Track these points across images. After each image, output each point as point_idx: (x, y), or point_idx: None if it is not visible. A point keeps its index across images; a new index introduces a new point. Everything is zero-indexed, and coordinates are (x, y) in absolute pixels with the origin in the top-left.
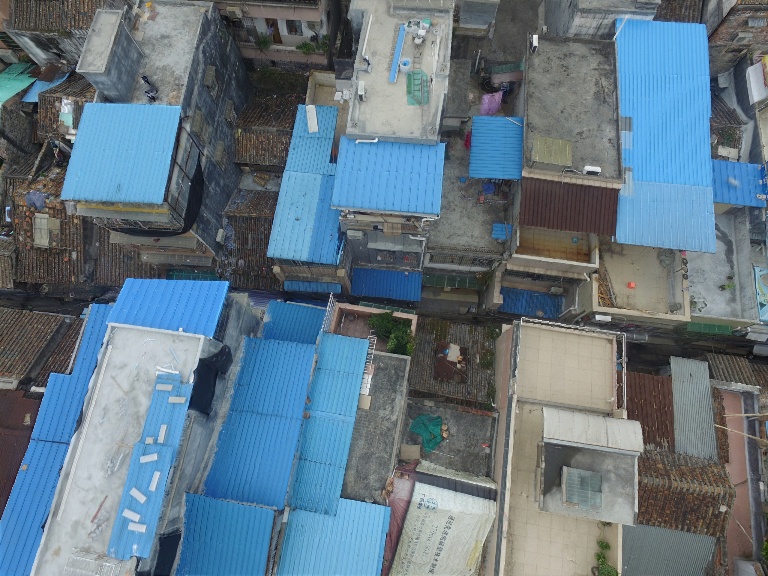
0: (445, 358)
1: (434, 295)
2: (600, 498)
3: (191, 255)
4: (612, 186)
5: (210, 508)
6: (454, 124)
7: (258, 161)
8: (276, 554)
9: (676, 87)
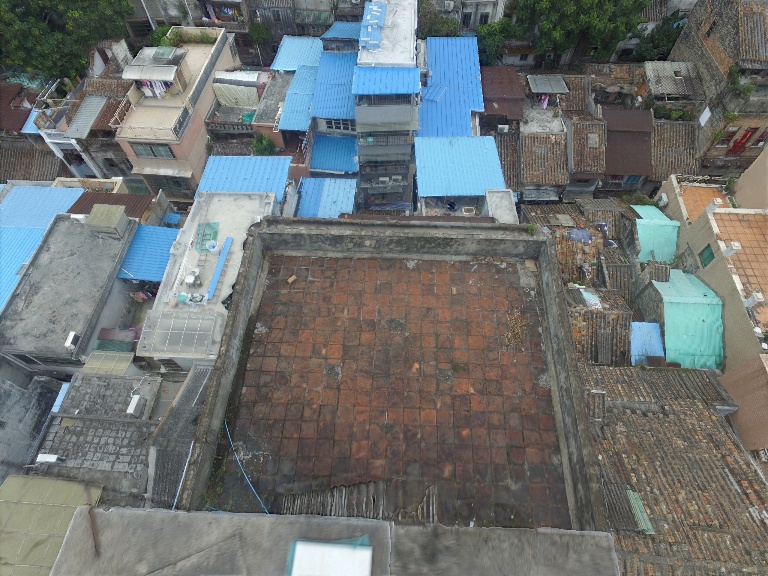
0: None
1: None
2: (157, 50)
3: None
4: None
5: None
6: None
7: None
8: None
9: None
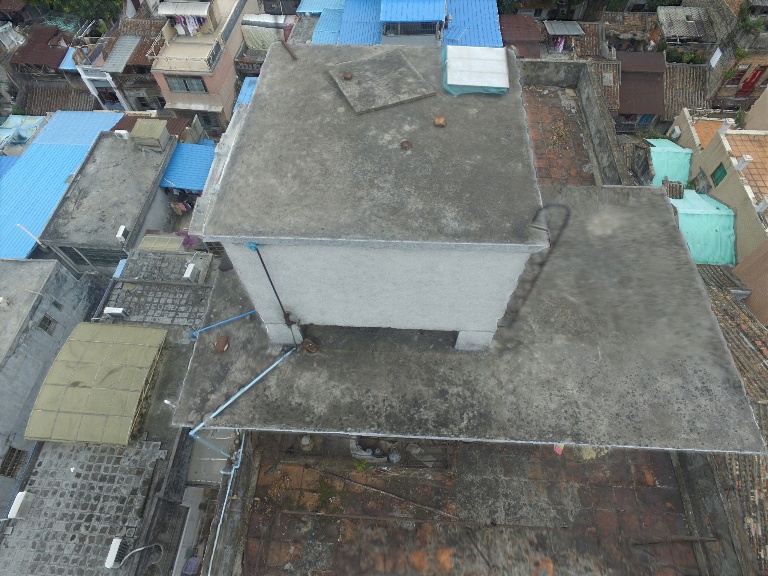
0: None
1: None
2: None
3: None
4: None
5: None
6: None
7: None
8: None
9: (6, 206)
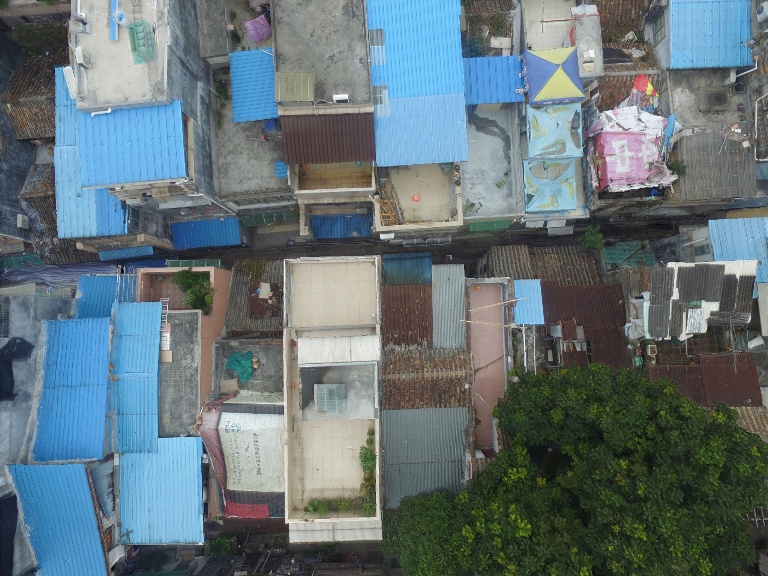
0: (257, 297)
1: (269, 229)
2: (345, 403)
3: (1, 244)
4: (364, 111)
5: (31, 473)
6: (222, 61)
7: (40, 134)
8: (115, 490)
9: None
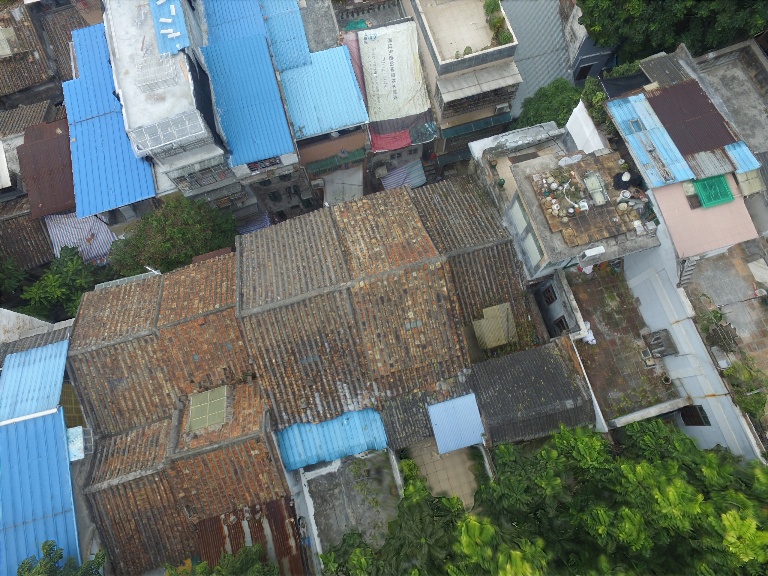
0: (353, 2)
1: None
2: None
3: None
4: None
5: (220, 50)
6: None
7: None
8: None
9: None
